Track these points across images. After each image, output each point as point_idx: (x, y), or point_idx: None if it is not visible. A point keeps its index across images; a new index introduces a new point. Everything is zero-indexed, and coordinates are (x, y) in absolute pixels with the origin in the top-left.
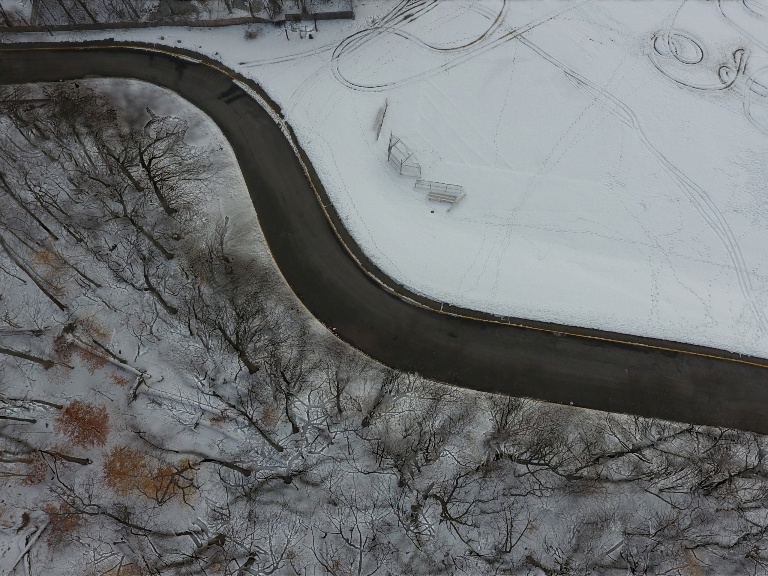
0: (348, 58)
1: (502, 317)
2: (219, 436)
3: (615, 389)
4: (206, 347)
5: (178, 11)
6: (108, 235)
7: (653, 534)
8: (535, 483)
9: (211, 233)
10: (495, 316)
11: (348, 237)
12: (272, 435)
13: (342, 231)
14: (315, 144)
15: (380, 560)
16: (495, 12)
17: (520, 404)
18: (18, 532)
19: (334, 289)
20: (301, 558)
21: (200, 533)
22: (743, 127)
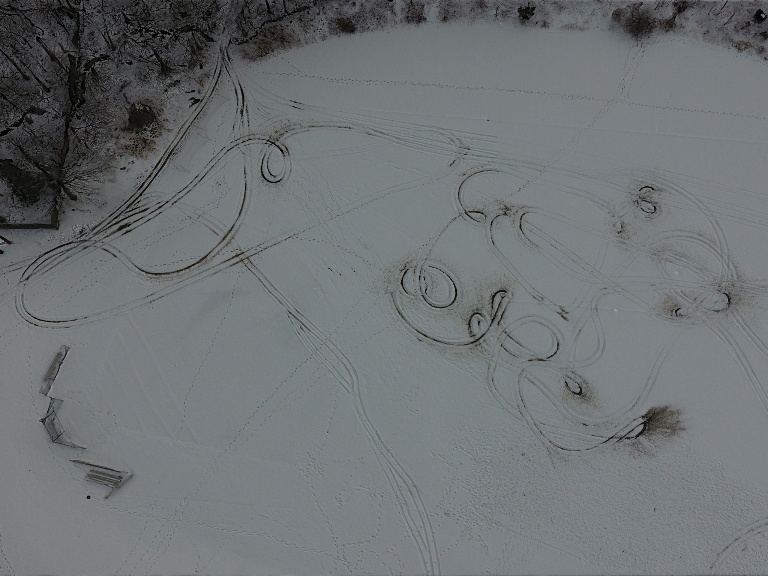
0: (38, 282)
1: None
2: None
3: None
4: None
5: None
6: None
7: None
8: None
9: None
10: None
11: None
12: None
13: None
14: None
15: None
16: (226, 226)
17: None
18: None
19: None
20: None
21: None
22: (481, 398)
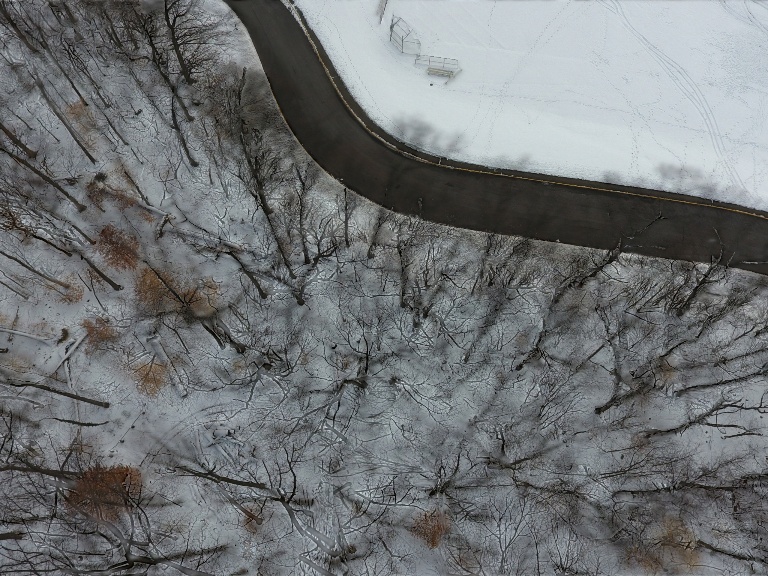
0: None
1: (495, 169)
2: (238, 266)
3: (598, 229)
4: (225, 192)
5: None
6: (134, 101)
7: (631, 346)
8: (524, 304)
9: (230, 85)
10: (489, 168)
11: (354, 103)
12: None
13: (348, 98)
14: (323, 25)
15: (385, 365)
16: None
17: (511, 241)
18: (58, 344)
19: (341, 147)
20: (313, 364)
21: (223, 336)
22: (719, 13)
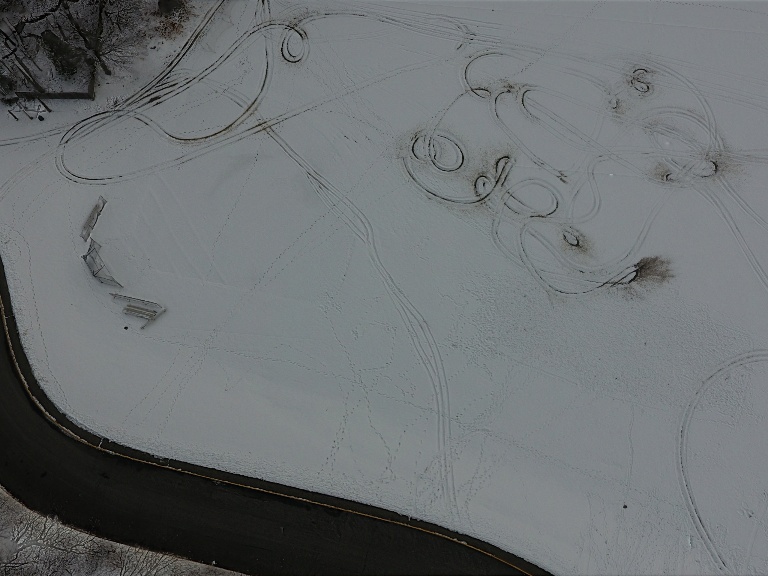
0: (77, 145)
1: (162, 459)
2: None
3: (265, 549)
4: None
5: None
6: None
7: None
8: None
9: None
10: (154, 457)
11: (21, 355)
12: None
13: (17, 347)
14: (13, 244)
15: None
16: (249, 99)
17: (156, 561)
18: None
19: None
20: None
21: None
22: (486, 248)
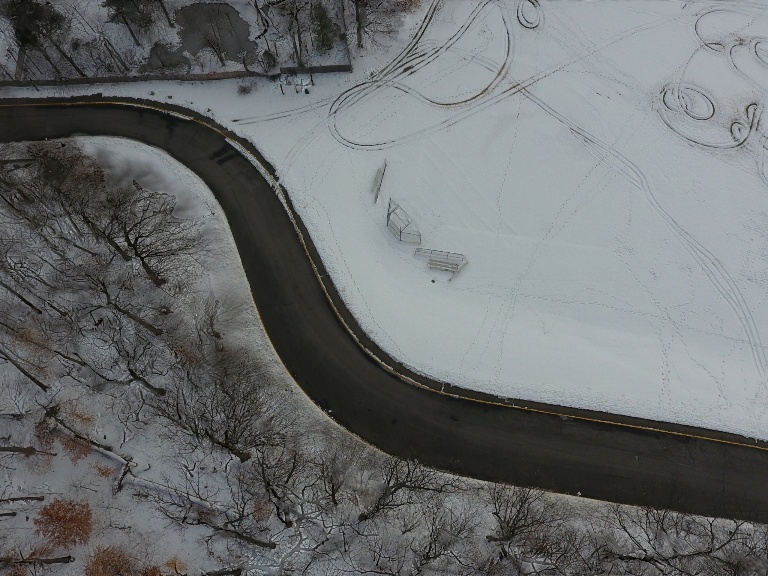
0: (345, 114)
1: (506, 399)
2: (208, 531)
3: (625, 478)
4: (195, 433)
5: (169, 64)
6: None
7: None
8: None
9: (200, 315)
10: (499, 398)
11: (345, 310)
12: (264, 532)
13: (338, 304)
14: (311, 209)
15: None
16: (498, 64)
17: (525, 495)
18: None
19: (330, 367)
20: None
21: None
22: (756, 188)
